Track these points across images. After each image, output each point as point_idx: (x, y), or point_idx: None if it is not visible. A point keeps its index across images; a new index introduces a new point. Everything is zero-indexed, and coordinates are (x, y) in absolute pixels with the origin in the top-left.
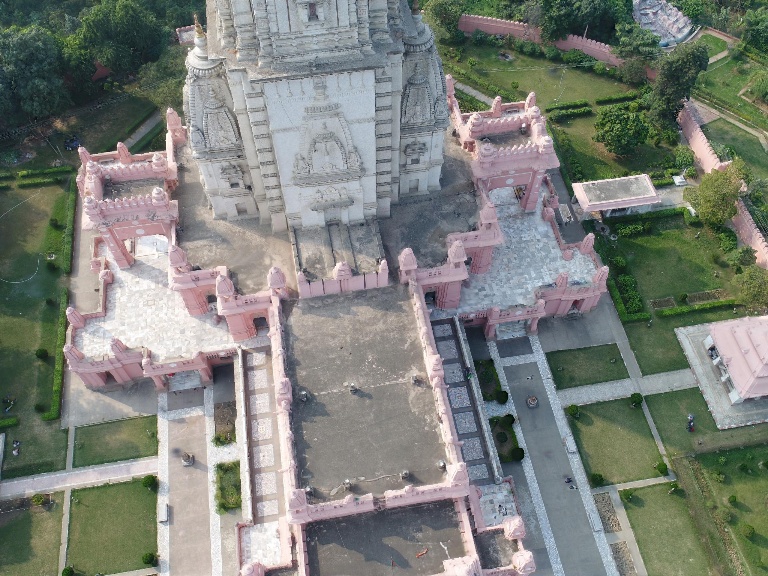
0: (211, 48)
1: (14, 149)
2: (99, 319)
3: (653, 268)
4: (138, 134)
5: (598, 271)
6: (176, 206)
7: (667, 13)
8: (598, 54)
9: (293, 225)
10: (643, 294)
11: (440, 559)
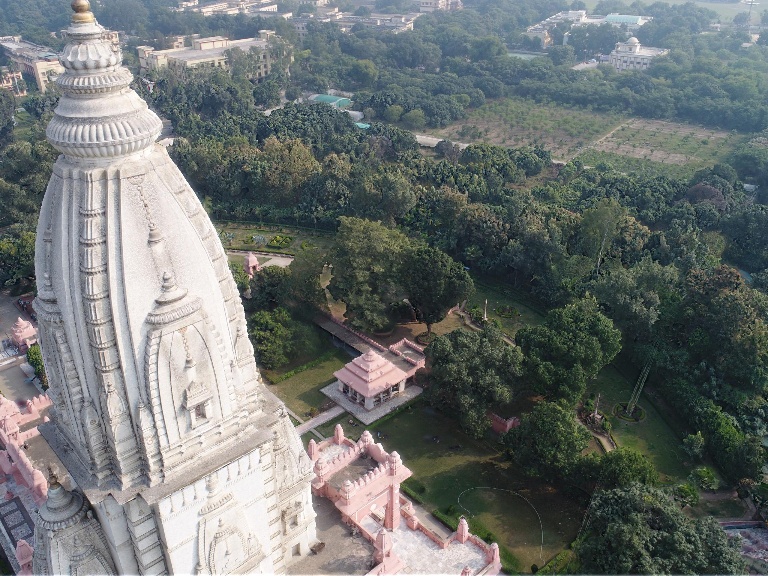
0: None
1: None
2: None
3: None
4: None
5: None
6: (314, 483)
7: None
8: None
9: None
10: None
11: (27, 428)
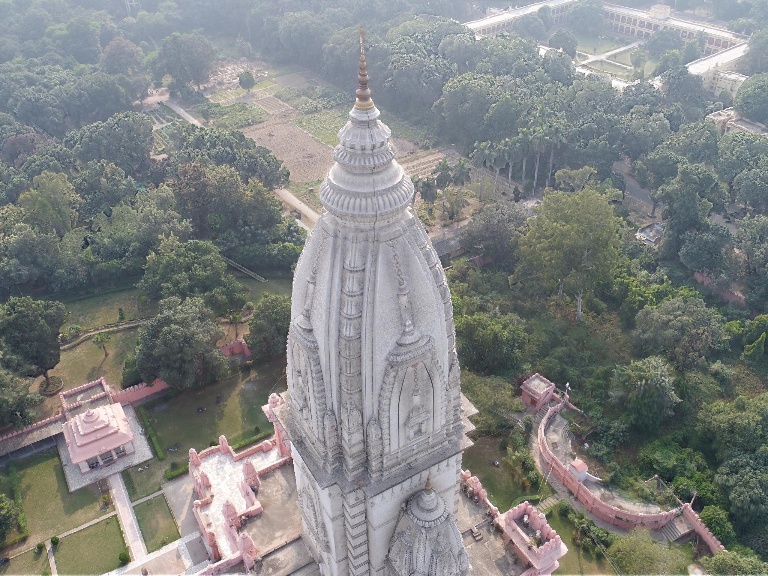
0: None
1: None
2: (232, 459)
3: None
4: None
5: None
6: None
7: None
8: None
9: None
10: None
11: None
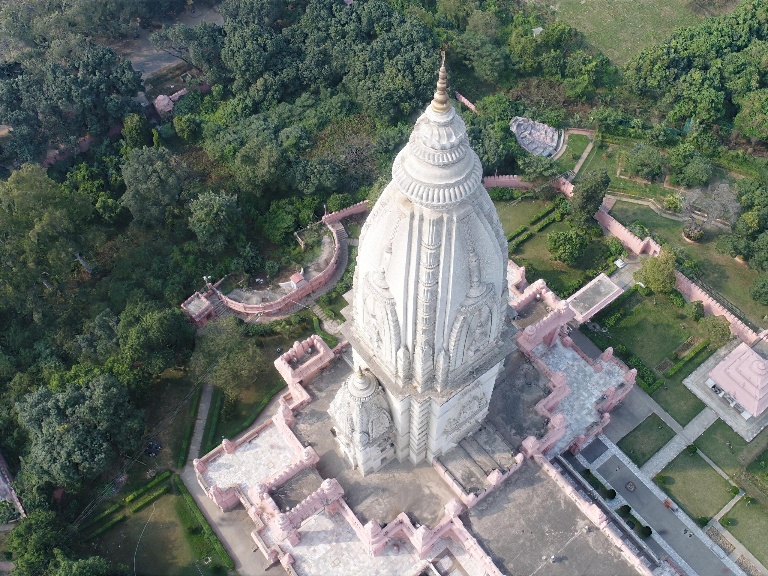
0: (394, 391)
1: (104, 480)
2: None
3: (643, 342)
4: (202, 413)
5: (629, 374)
6: (338, 484)
7: (537, 129)
8: (510, 183)
9: (435, 456)
10: (648, 365)
11: None
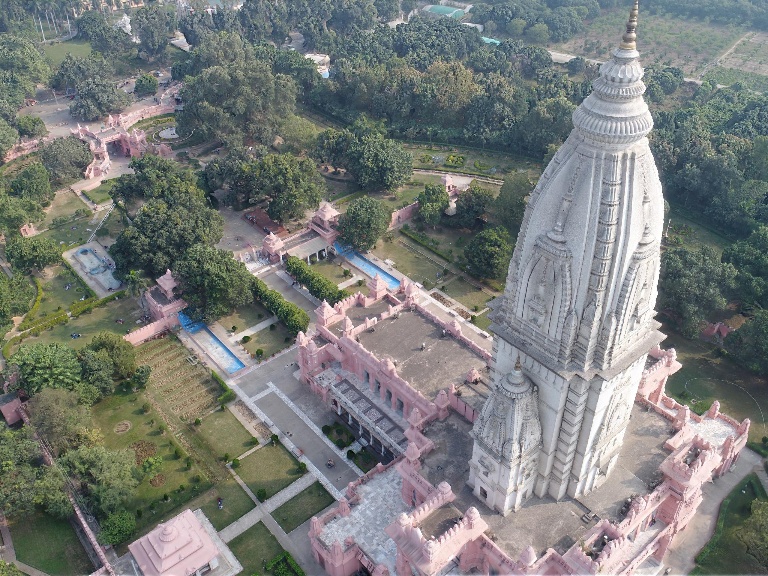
0: None
1: None
2: None
3: None
4: None
5: None
6: None
7: None
8: None
9: None
10: None
11: None
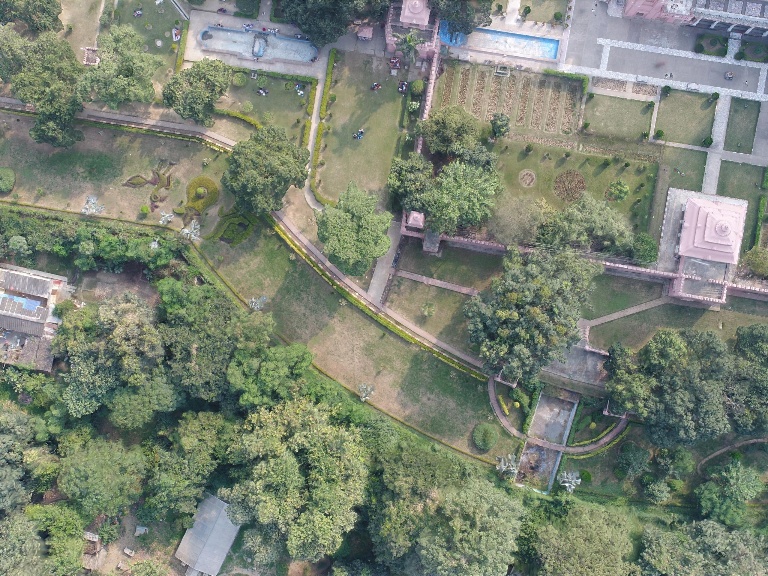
0: None
1: None
2: None
3: None
4: None
5: None
6: None
7: None
8: None
9: None
10: None
11: None
